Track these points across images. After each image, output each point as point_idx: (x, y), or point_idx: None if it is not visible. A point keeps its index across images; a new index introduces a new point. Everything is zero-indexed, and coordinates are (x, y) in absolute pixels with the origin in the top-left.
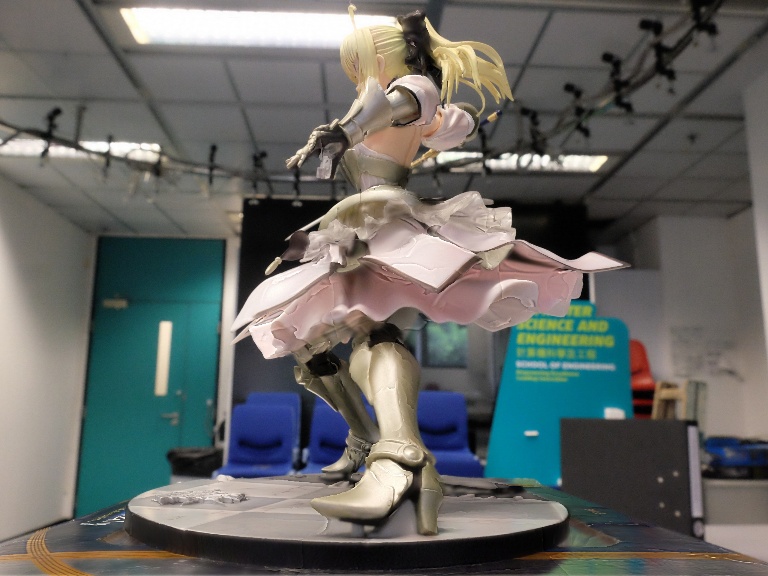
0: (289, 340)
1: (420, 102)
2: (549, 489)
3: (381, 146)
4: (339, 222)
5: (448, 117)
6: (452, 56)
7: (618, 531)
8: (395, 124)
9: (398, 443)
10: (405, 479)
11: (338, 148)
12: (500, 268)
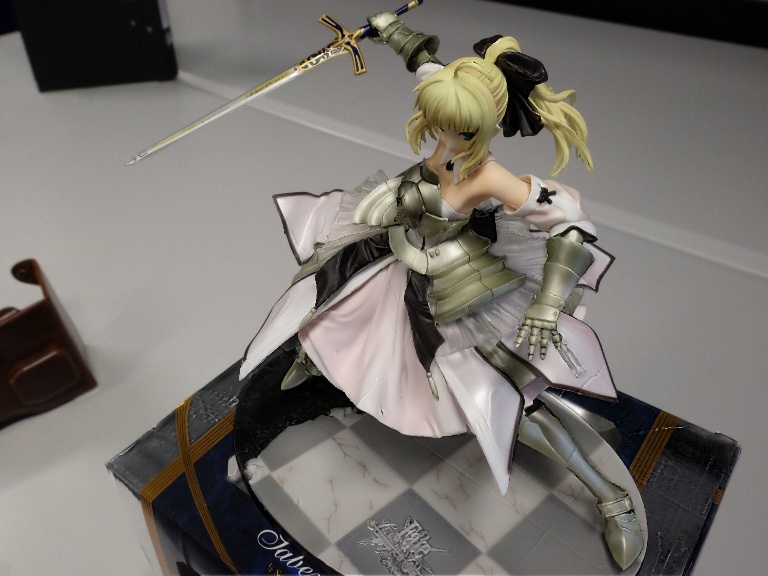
0: None
1: None
2: None
3: None
4: None
5: None
6: (577, 141)
7: (583, 400)
8: None
9: (621, 501)
10: None
11: None
12: None
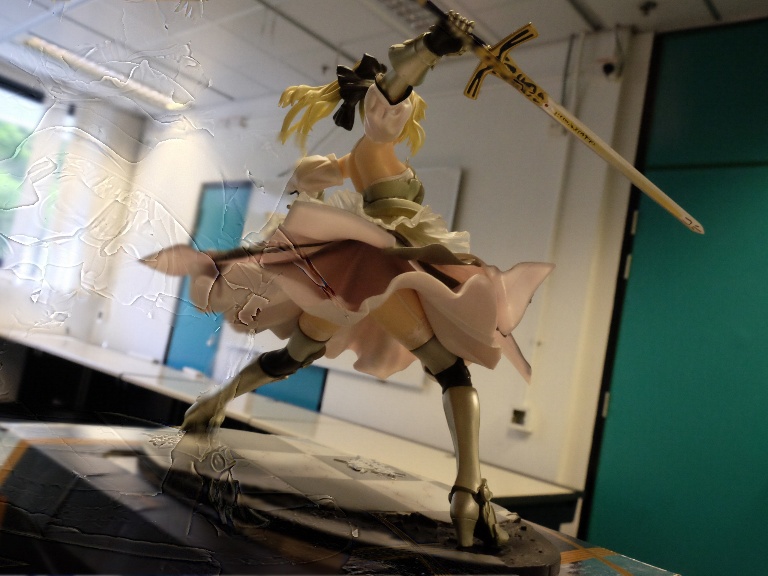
0: (149, 308)
1: None
2: None
3: None
4: None
5: None
6: None
7: None
8: None
9: None
10: None
11: None
12: None
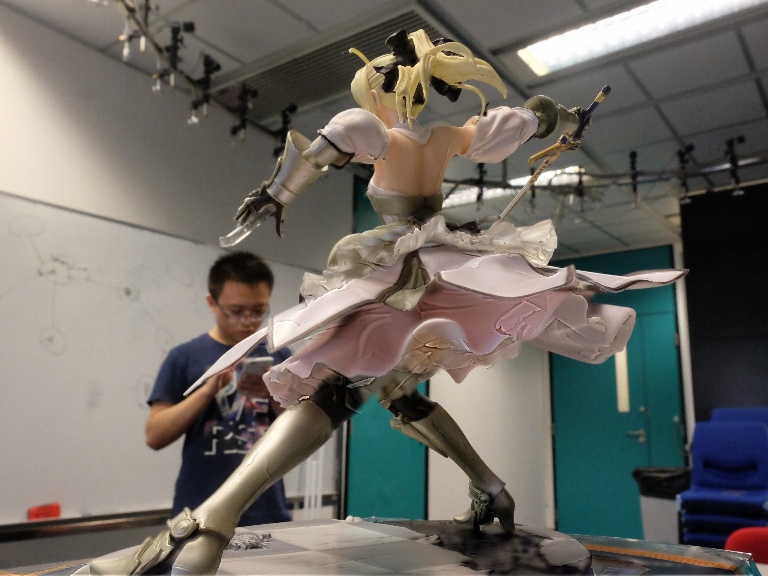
0: None
1: (334, 142)
2: (725, 573)
3: (385, 183)
4: (310, 276)
5: (486, 125)
6: None
7: None
8: (333, 168)
9: (185, 515)
10: (154, 554)
11: (273, 209)
12: (420, 307)
